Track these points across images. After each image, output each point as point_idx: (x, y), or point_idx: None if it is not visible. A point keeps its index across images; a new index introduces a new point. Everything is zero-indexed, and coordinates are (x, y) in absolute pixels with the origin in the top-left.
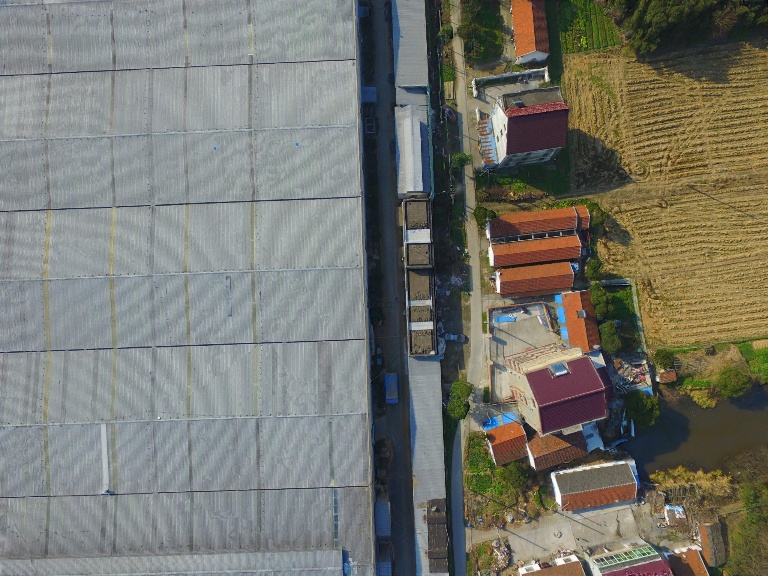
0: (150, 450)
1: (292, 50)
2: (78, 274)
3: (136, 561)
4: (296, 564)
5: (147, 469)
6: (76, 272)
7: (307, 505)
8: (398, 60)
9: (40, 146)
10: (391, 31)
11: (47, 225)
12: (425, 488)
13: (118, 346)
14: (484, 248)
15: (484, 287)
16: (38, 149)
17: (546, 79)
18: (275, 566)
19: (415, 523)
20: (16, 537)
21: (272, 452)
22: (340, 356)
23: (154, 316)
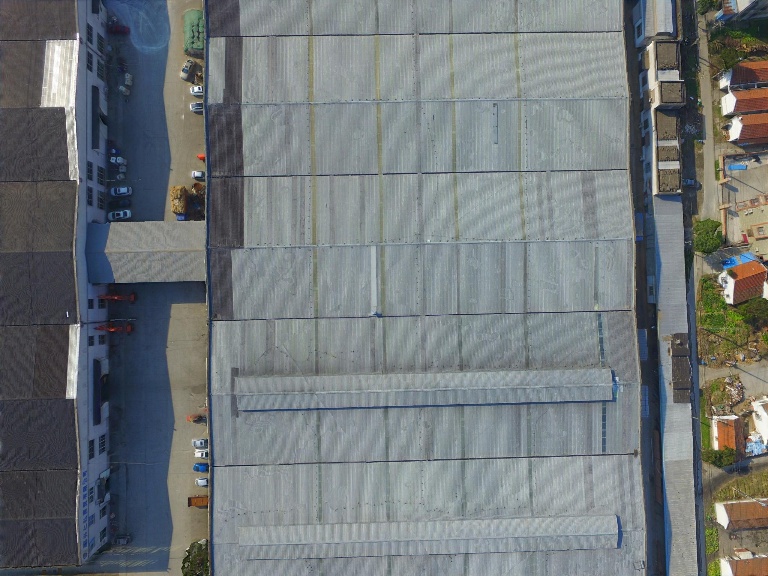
0: (419, 273)
1: None
2: (345, 98)
3: (410, 378)
4: (567, 381)
5: (415, 292)
6: (343, 96)
7: (572, 328)
8: None
9: None
10: None
11: (310, 50)
12: (669, 322)
13: (383, 172)
14: (716, 99)
15: (716, 136)
16: None
17: None
18: (547, 383)
19: (660, 355)
20: (285, 357)
21: (539, 276)
22: (604, 185)
23: (420, 142)
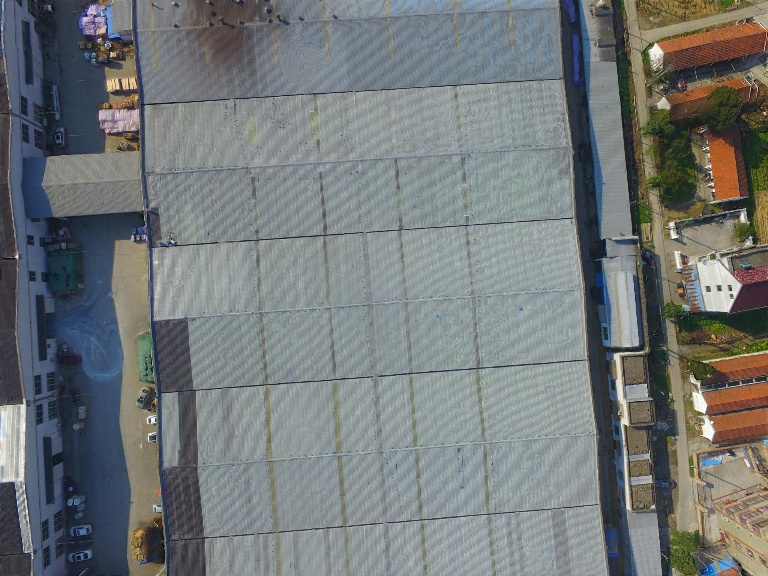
0: None
1: (507, 209)
2: (304, 453)
3: None
4: None
5: None
6: (302, 451)
7: None
8: (602, 208)
9: (255, 320)
10: (585, 172)
11: (266, 401)
12: None
13: (348, 524)
14: (687, 391)
15: (689, 431)
16: (253, 323)
17: (742, 219)
18: None
19: None
20: None
21: None
22: (575, 523)
23: (385, 492)
